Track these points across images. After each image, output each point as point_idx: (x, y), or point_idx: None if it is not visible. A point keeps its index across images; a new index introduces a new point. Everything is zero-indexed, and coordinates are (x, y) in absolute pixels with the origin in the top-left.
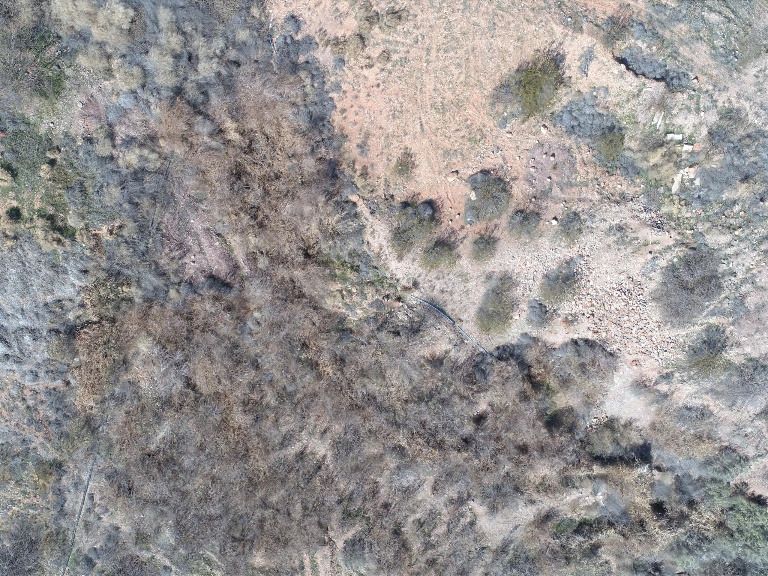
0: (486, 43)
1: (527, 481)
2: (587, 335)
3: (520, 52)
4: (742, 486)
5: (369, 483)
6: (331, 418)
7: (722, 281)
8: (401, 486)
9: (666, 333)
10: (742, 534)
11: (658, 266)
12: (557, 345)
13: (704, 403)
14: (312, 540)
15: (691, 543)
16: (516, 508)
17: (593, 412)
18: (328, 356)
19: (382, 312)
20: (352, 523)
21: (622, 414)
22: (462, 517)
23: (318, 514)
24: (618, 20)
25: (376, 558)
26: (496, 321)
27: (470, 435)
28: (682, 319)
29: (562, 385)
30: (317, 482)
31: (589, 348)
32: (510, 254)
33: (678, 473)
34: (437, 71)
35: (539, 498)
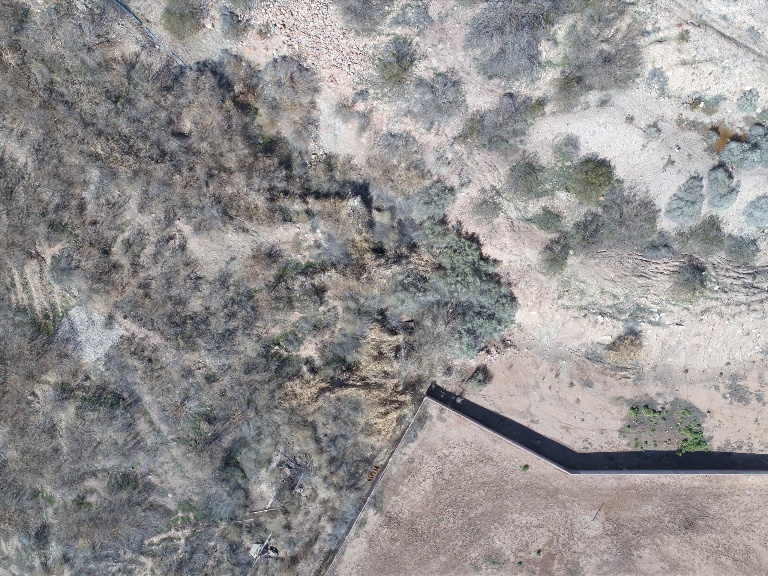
0: None
1: (236, 205)
2: (285, 51)
3: None
4: (457, 225)
5: (75, 198)
6: (27, 121)
7: None
8: (107, 202)
9: (352, 41)
10: (454, 270)
11: None
12: (262, 67)
13: (406, 129)
14: (12, 247)
15: (407, 281)
16: (215, 223)
17: (311, 148)
18: (7, 42)
19: (62, 2)
20: (59, 238)
21: (339, 150)
22: (171, 239)
23: (24, 227)
24: None
25: (83, 274)
26: (188, 28)
27: (169, 147)
28: (366, 26)
29: (271, 111)
30: (21, 192)
31: (285, 62)
32: None
33: (401, 218)
34: None
35: (253, 228)
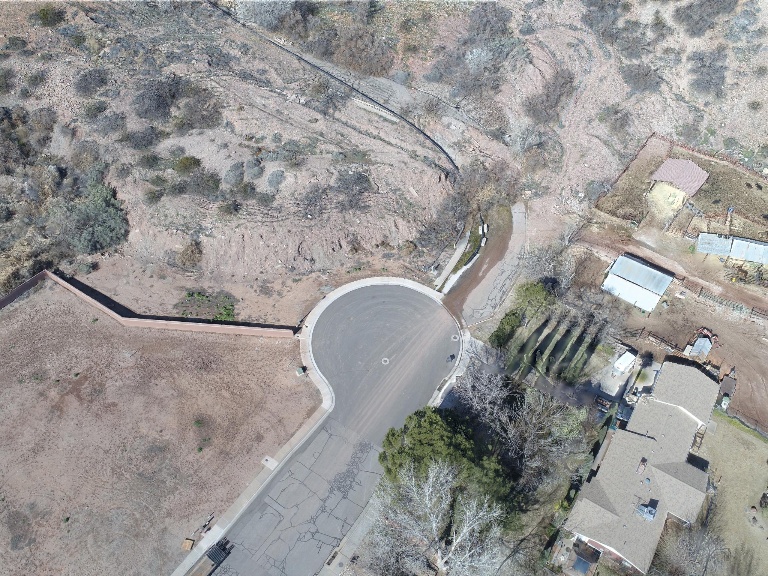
0: (33, 2)
1: None
2: None
3: (47, 7)
4: None
5: None
6: None
7: (107, 81)
8: None
9: (77, 99)
10: None
11: (80, 74)
12: None
13: None
14: None
15: (63, 205)
16: None
17: (44, 151)
18: None
19: None
20: None
21: (59, 153)
22: None
23: None
24: (94, 9)
25: None
26: (2, 92)
27: None
28: (86, 95)
29: (28, 131)
30: None
31: None
32: (14, 61)
33: None
34: (10, 5)
35: None
